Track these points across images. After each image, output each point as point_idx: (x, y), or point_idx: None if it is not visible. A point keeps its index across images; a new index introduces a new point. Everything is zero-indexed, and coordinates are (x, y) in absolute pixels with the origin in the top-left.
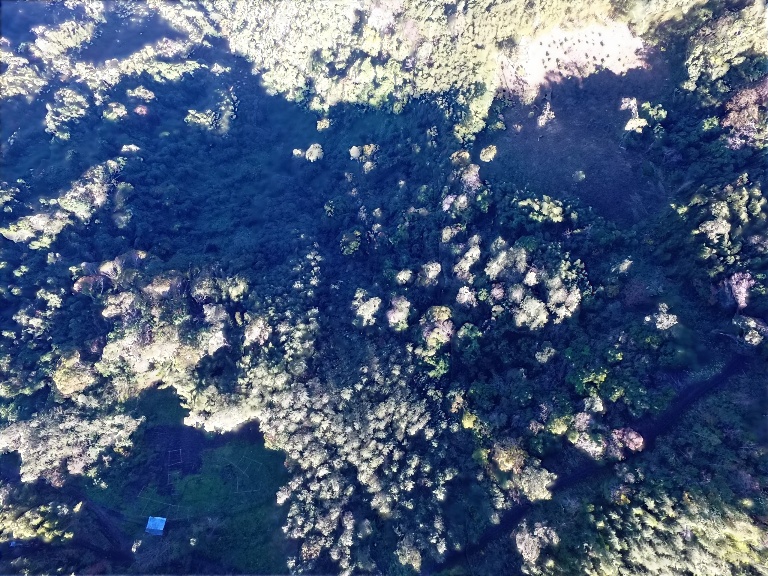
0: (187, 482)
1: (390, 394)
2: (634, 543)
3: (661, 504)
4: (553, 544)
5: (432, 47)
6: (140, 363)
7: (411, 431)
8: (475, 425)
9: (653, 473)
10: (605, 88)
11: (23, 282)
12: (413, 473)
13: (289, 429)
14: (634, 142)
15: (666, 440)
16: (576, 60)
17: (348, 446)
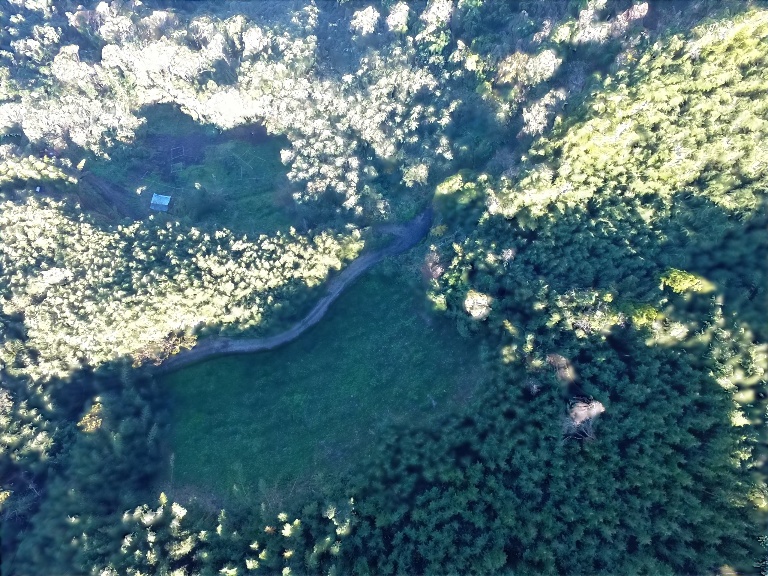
0: (191, 171)
1: (391, 72)
2: (642, 84)
3: (668, 45)
4: (560, 108)
5: None
6: (139, 61)
7: (414, 86)
8: (478, 65)
9: (659, 32)
10: None
11: (20, 27)
12: (417, 117)
13: (291, 104)
14: None
15: (672, 11)
16: None
17: (351, 111)
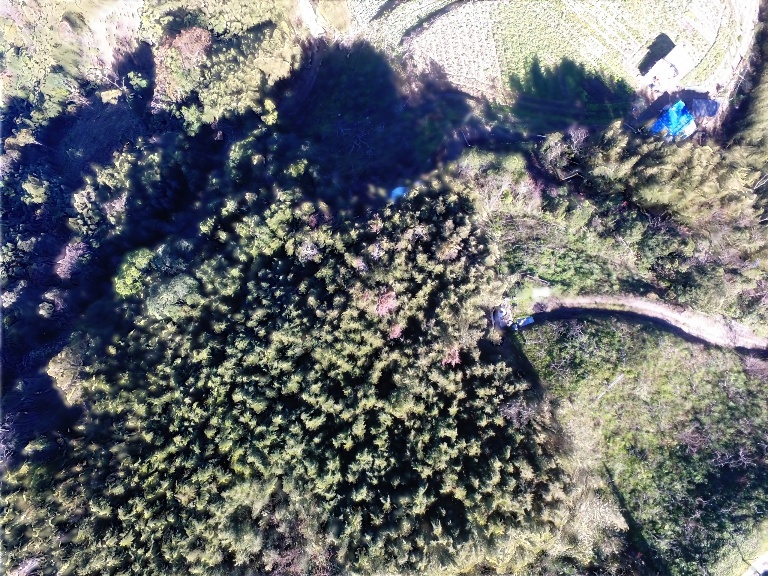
0: None
1: None
2: None
3: None
4: None
5: (30, 32)
6: None
7: None
8: None
9: None
10: (150, 62)
11: None
12: None
13: None
14: (133, 115)
15: None
16: (125, 35)
17: None
